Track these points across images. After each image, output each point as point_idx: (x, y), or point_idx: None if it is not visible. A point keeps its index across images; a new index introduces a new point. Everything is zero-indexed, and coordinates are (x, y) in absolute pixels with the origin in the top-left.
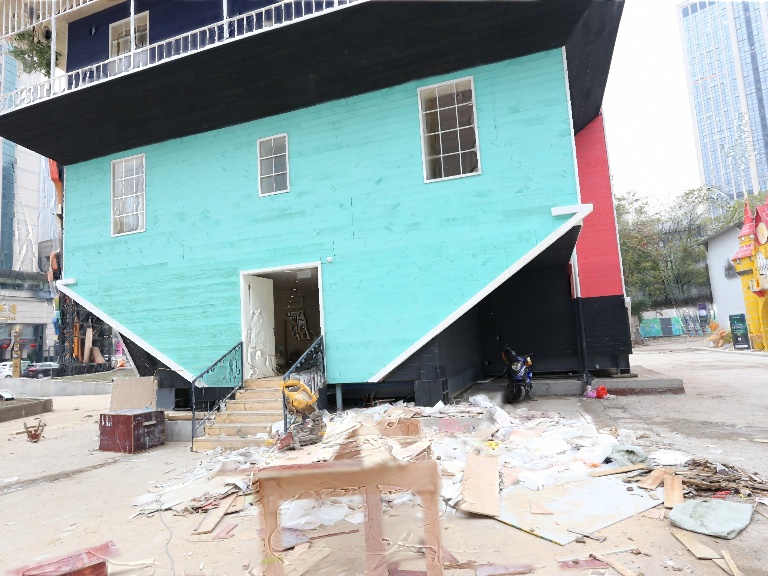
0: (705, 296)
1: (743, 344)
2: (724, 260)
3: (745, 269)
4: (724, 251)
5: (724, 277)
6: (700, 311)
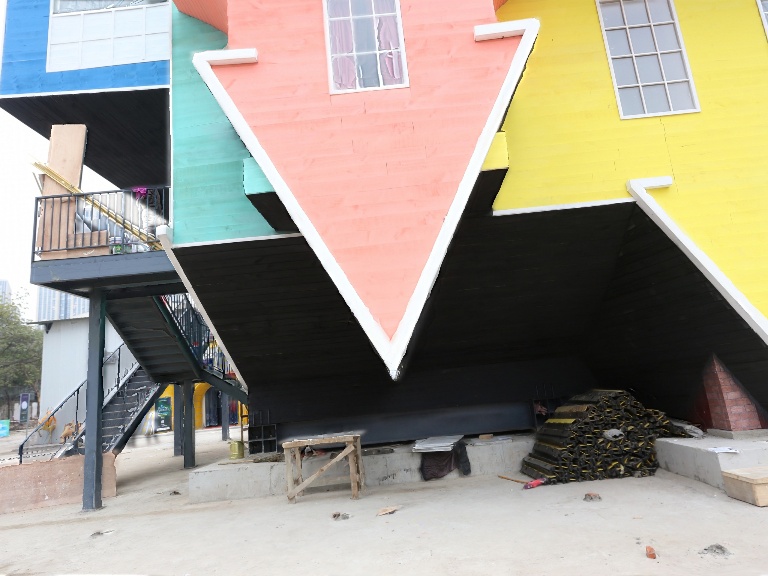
0: (32, 385)
1: (166, 426)
2: None
3: None
4: None
5: (83, 364)
6: (23, 403)
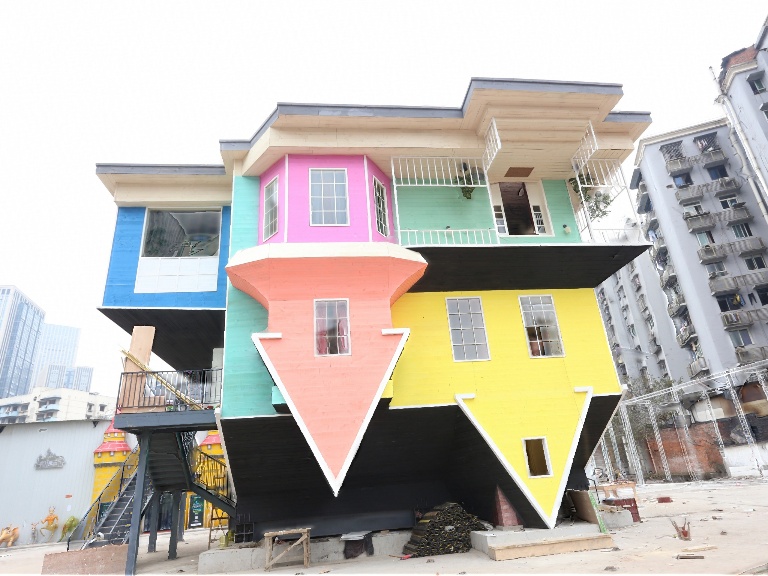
0: None
1: None
2: (38, 449)
3: (117, 461)
4: (43, 440)
5: (30, 467)
6: None
